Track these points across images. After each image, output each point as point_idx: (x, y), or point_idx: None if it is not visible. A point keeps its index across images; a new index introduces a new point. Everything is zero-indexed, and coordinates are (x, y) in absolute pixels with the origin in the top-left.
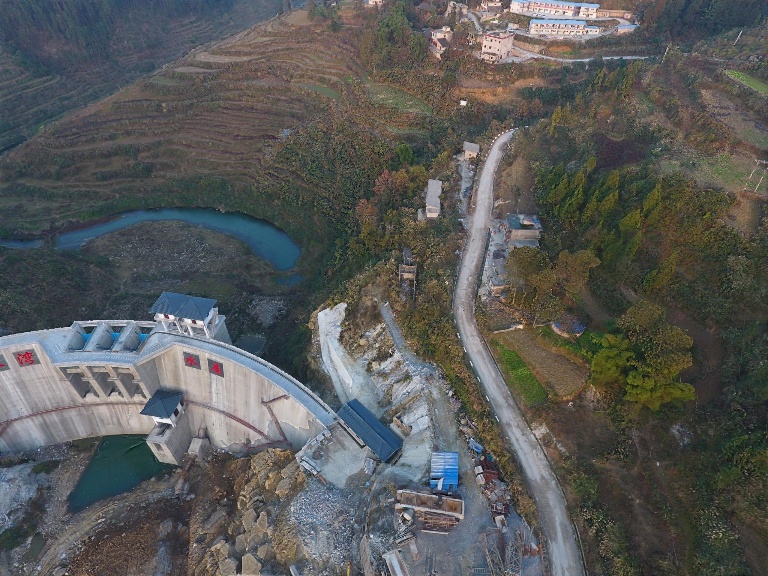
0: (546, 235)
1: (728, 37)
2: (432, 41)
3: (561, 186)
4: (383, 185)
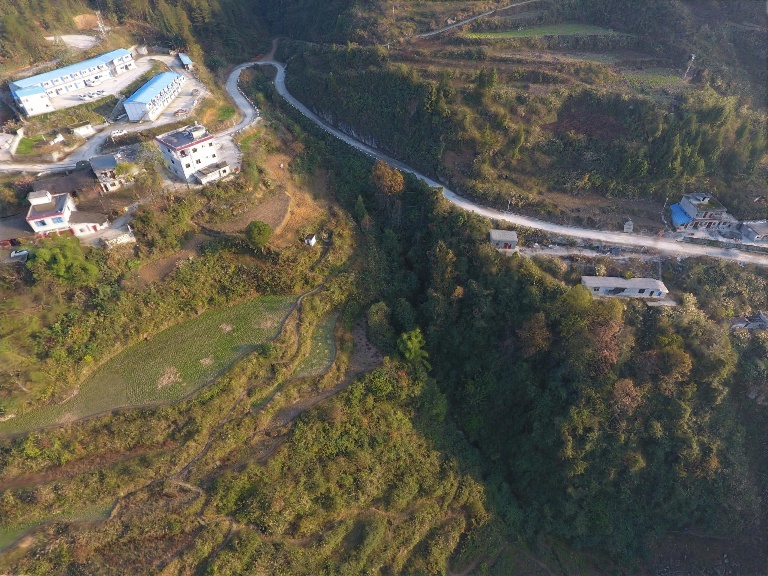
0: (761, 180)
1: (382, 17)
2: (39, 237)
3: (679, 158)
4: (630, 337)
